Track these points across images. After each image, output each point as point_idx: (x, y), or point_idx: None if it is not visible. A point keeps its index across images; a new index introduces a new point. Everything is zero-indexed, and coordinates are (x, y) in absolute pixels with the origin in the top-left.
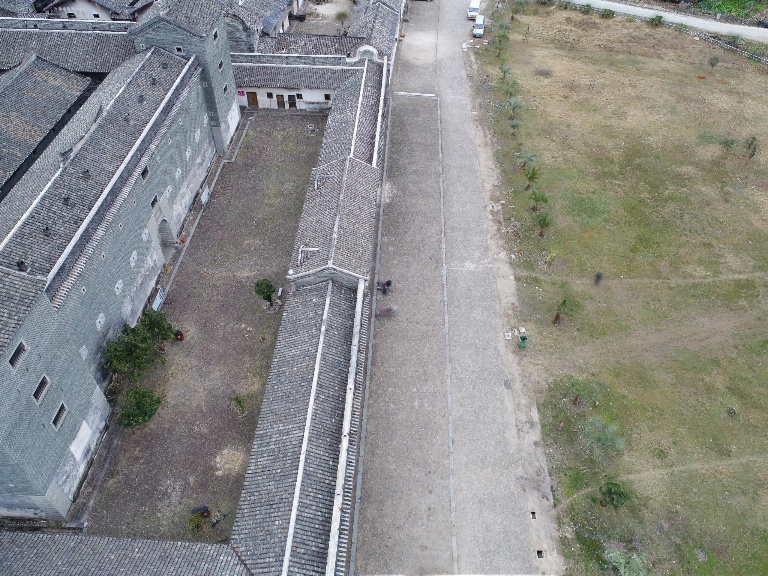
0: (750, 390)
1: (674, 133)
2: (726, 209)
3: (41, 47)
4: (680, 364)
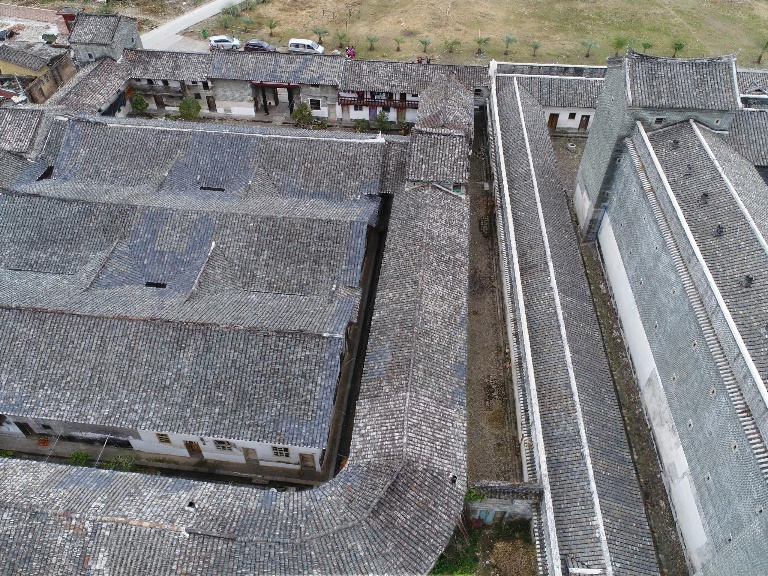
0: (764, 25)
1: (509, 3)
2: (603, 4)
3: (766, 216)
4: (760, 37)
